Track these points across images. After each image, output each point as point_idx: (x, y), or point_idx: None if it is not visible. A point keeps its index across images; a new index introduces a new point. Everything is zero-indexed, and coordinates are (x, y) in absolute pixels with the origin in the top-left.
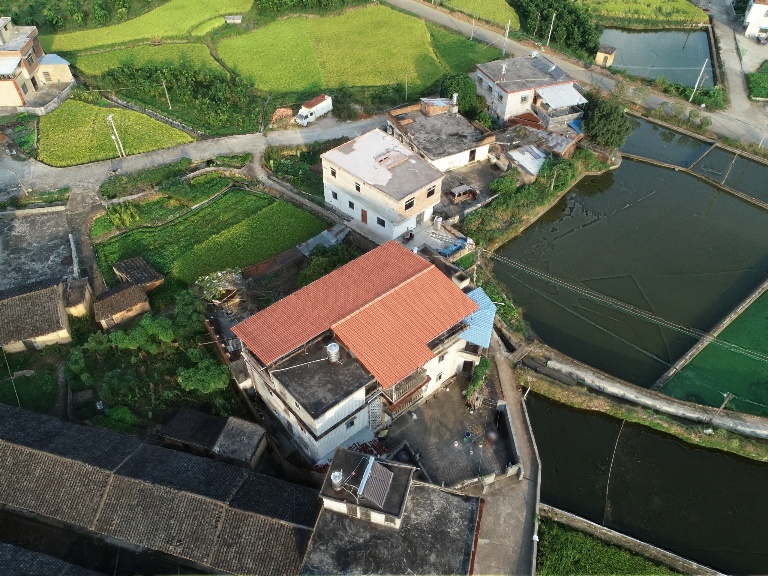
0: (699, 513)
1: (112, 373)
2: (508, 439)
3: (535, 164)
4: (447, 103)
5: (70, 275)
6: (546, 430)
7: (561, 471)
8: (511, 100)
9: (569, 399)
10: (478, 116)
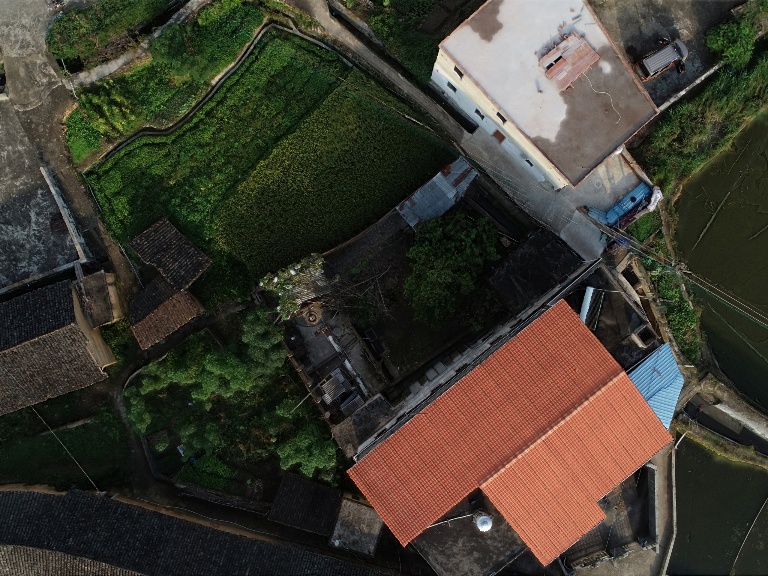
0: None
1: (189, 432)
2: (646, 499)
3: None
4: None
5: (75, 262)
6: (690, 488)
7: (695, 537)
8: None
9: (728, 455)
10: None
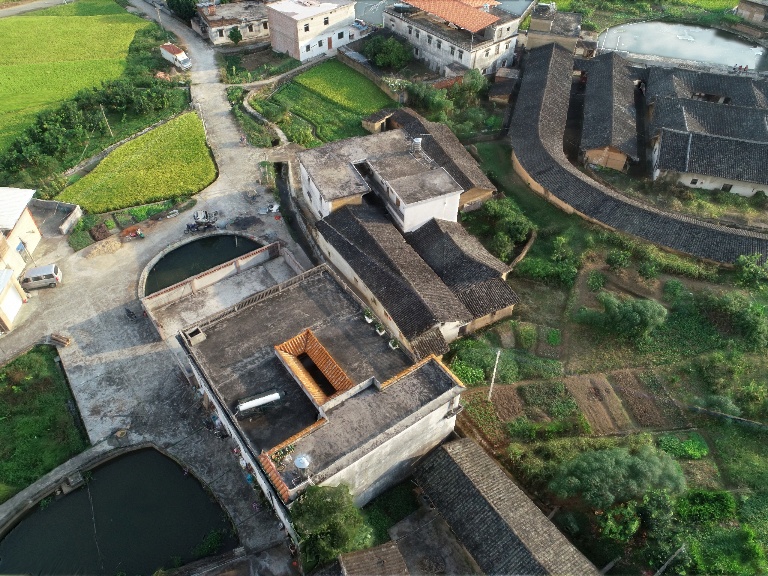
0: (507, 6)
1: None
2: None
3: None
4: None
5: None
6: None
7: None
8: None
9: None
10: (220, 2)
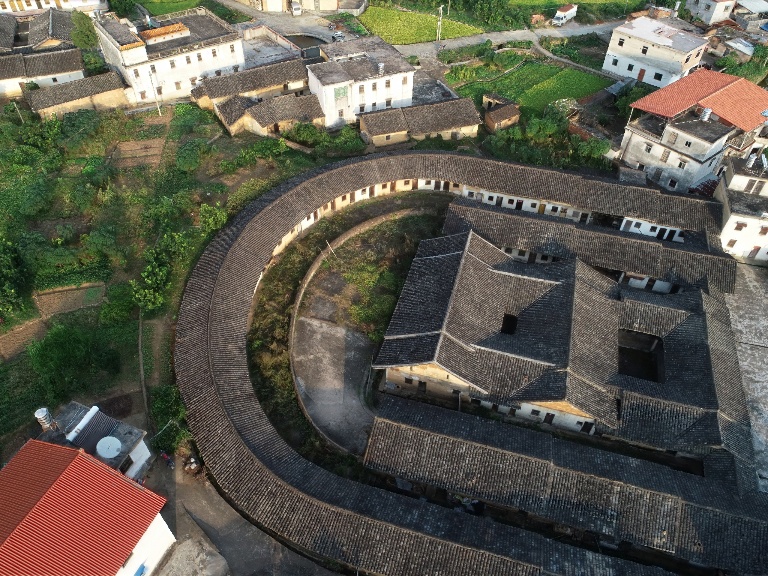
0: None
1: (525, 147)
2: None
3: (748, 50)
4: (669, 10)
5: None
6: None
7: None
8: (718, 8)
9: None
10: None
